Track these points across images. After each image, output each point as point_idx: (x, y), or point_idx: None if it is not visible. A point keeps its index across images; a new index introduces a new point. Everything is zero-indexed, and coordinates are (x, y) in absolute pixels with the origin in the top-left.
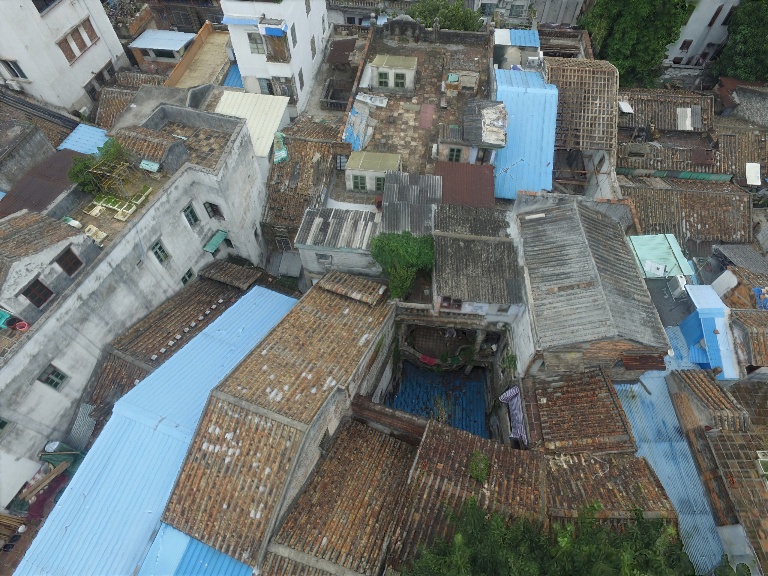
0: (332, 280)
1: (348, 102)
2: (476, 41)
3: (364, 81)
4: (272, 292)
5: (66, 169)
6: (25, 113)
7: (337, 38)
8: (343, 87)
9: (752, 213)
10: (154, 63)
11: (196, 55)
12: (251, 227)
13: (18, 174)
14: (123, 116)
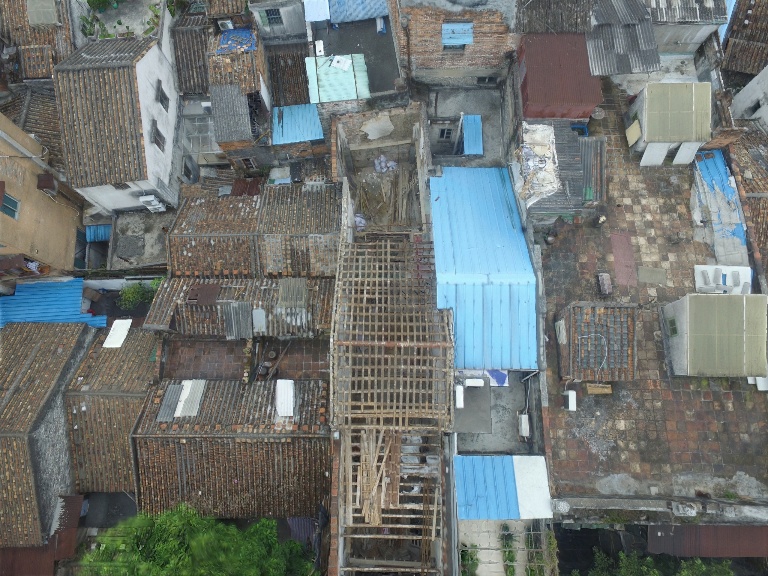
0: None
1: None
2: None
3: None
4: None
5: None
6: None
7: None
8: None
9: (174, 220)
10: None
11: None
12: (767, 91)
13: None
14: None
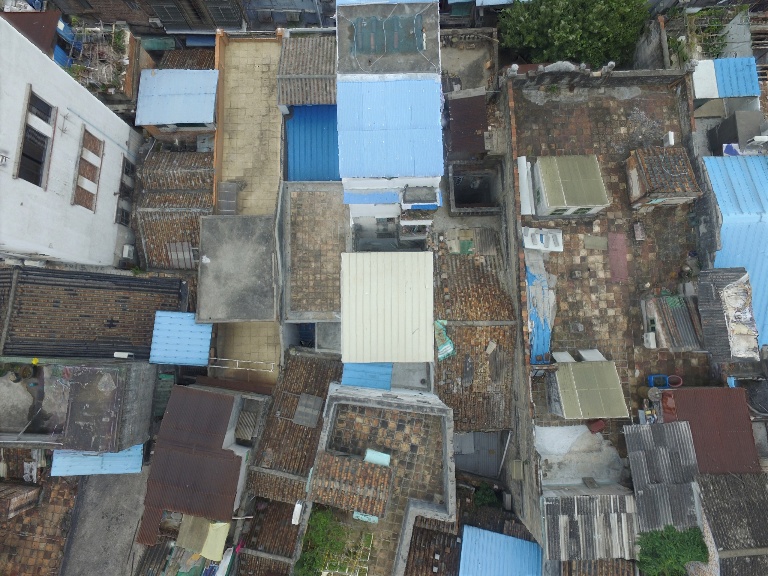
0: (582, 571)
1: (519, 260)
2: (660, 81)
3: (523, 201)
4: (485, 532)
5: (199, 427)
6: (64, 288)
7: (453, 94)
8: (468, 168)
9: None
10: (176, 133)
11: (224, 100)
12: None
13: (134, 428)
14: (202, 282)
